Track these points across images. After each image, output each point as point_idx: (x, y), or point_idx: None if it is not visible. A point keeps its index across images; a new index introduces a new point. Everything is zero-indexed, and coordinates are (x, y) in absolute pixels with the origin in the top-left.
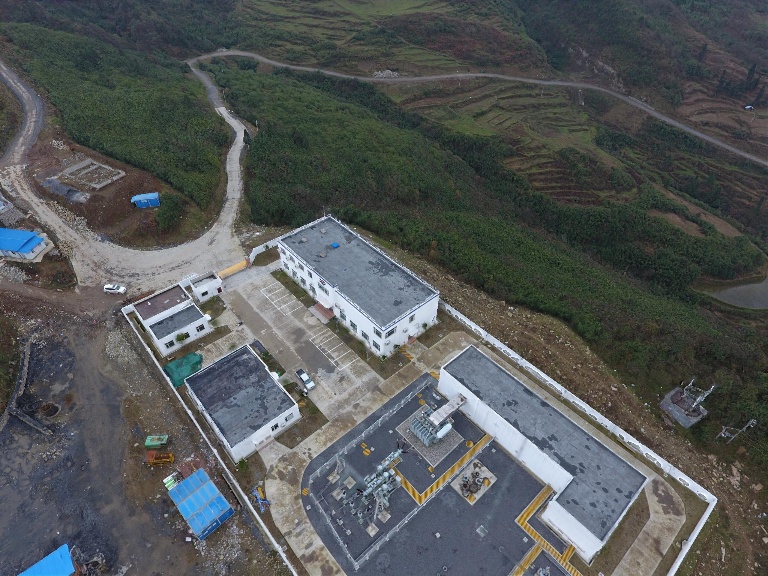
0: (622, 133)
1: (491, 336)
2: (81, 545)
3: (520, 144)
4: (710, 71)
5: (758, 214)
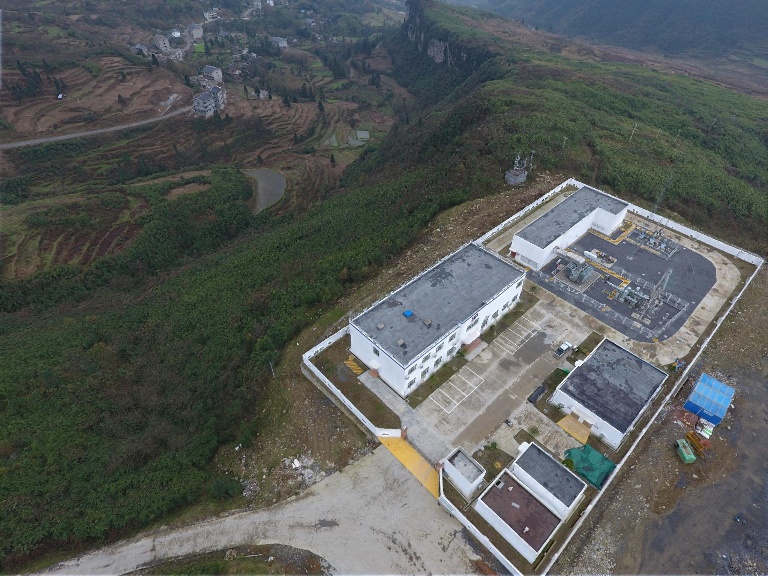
0: (8, 180)
1: None
2: None
3: None
4: None
5: (182, 156)
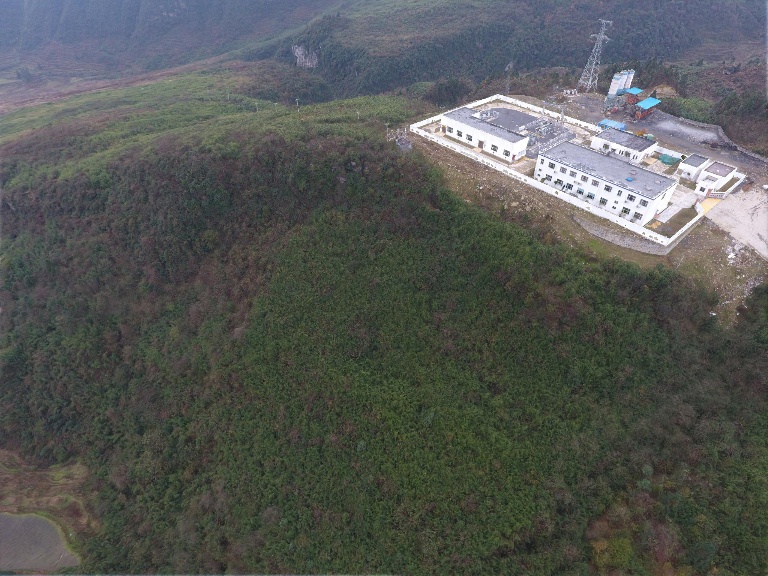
0: None
1: (499, 164)
2: None
3: None
4: None
5: None
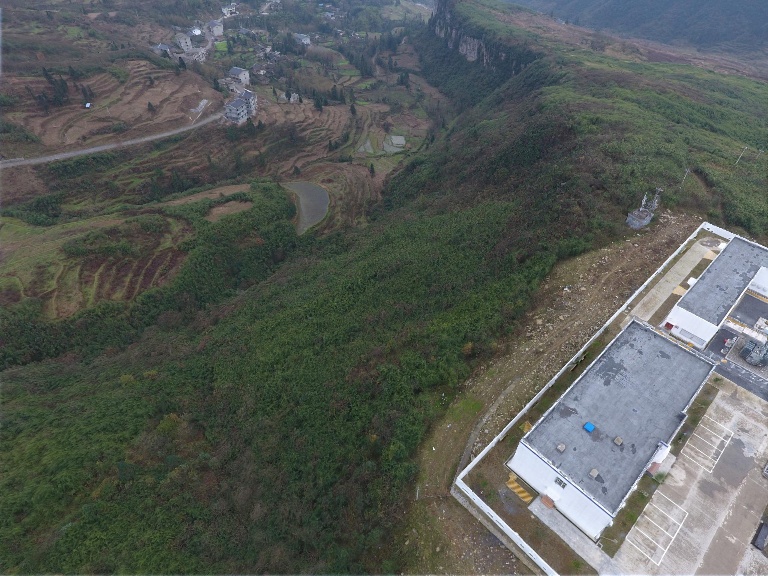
0: (38, 199)
1: None
2: None
3: (18, 290)
4: (8, 95)
5: (216, 168)
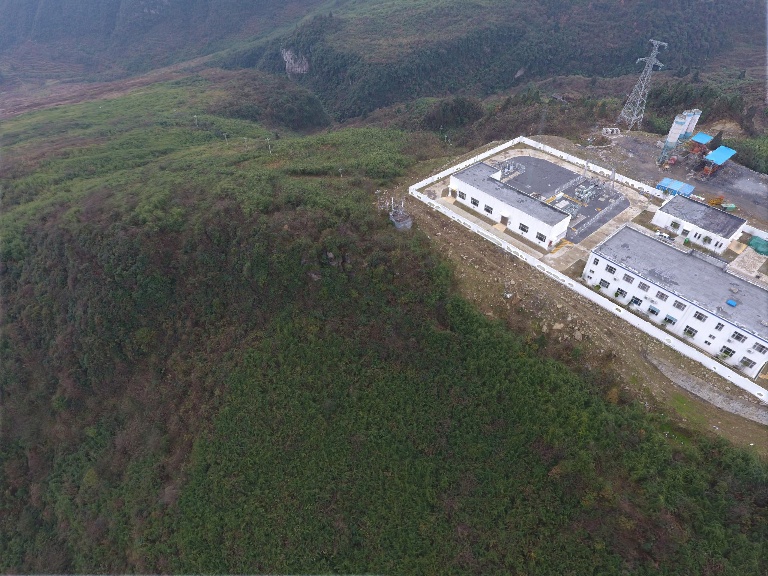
0: None
1: None
2: (717, 183)
3: None
4: None
5: None
